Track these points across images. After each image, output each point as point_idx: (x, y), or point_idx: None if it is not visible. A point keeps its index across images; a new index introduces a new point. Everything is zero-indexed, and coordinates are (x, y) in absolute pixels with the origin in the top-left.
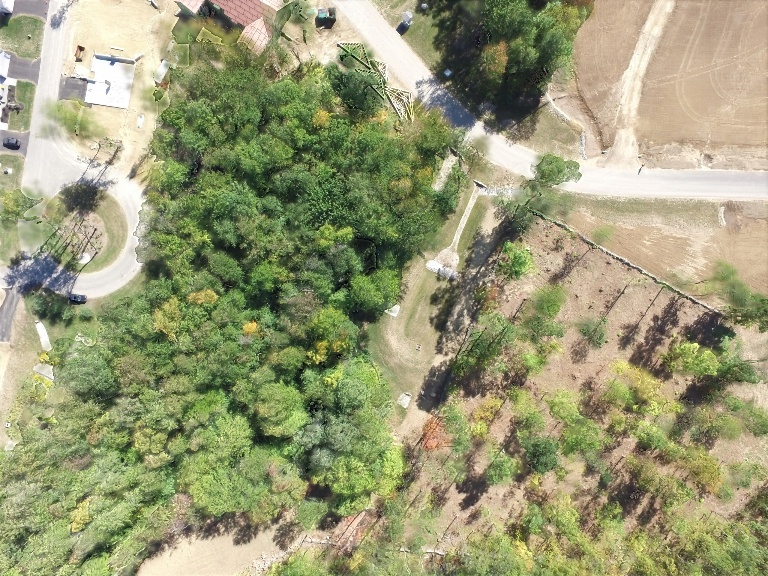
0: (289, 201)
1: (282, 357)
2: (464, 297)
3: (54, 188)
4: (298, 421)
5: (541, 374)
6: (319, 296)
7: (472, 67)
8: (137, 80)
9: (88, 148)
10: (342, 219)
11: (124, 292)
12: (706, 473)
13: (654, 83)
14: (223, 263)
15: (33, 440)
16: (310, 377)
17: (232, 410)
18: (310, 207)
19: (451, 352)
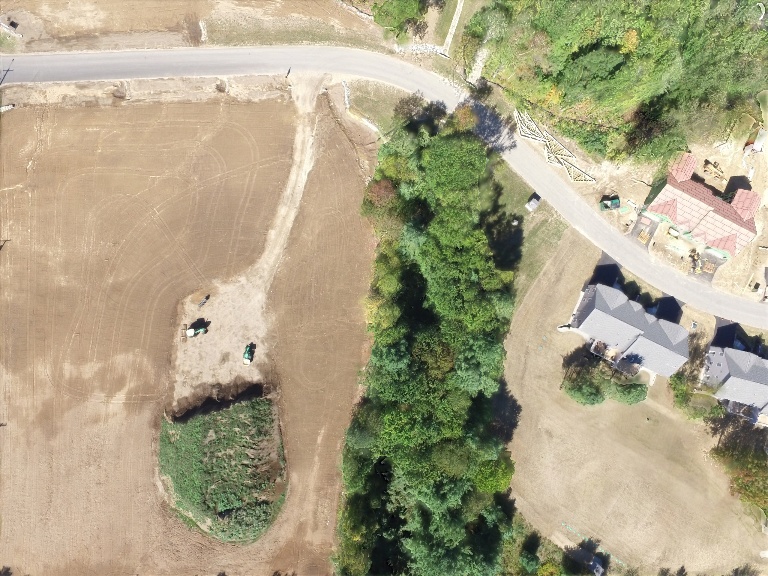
0: None
1: None
2: None
3: None
4: None
5: None
6: None
7: None
8: None
9: None
10: None
11: None
12: None
13: (281, 159)
14: None
15: None
16: None
17: None
18: None
19: None
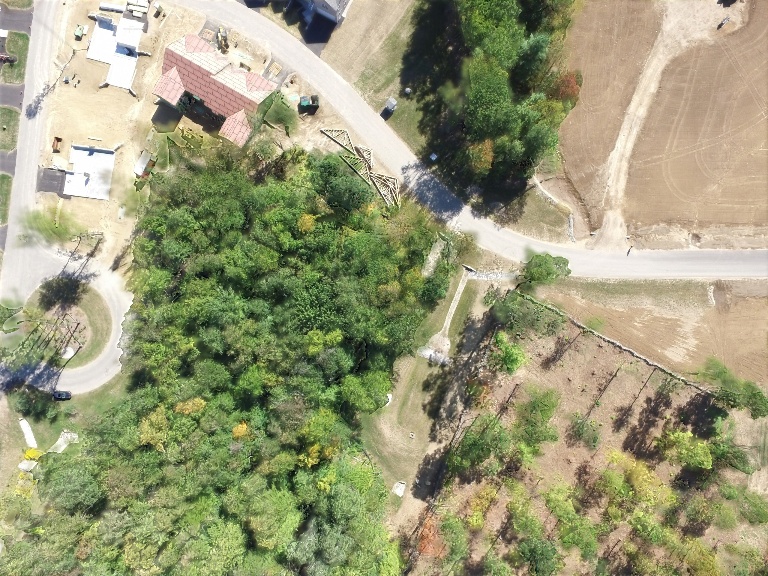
0: (276, 302)
1: (273, 465)
2: (456, 383)
3: (34, 282)
4: (292, 526)
5: (536, 459)
6: (309, 398)
7: (458, 151)
8: (117, 170)
9: (68, 240)
10: (330, 323)
11: (110, 387)
12: (703, 571)
13: (640, 164)
14: (210, 371)
15: (19, 555)
16: (302, 480)
17: (224, 514)
18: (297, 313)
19: (445, 439)
